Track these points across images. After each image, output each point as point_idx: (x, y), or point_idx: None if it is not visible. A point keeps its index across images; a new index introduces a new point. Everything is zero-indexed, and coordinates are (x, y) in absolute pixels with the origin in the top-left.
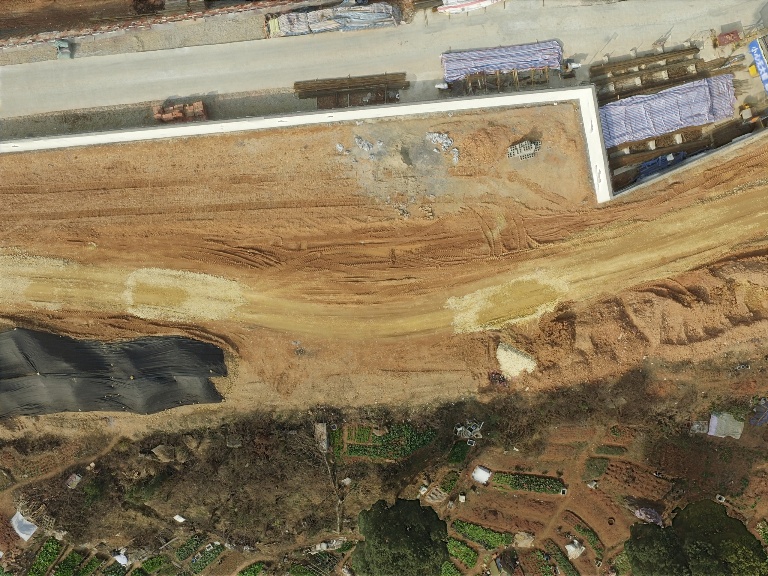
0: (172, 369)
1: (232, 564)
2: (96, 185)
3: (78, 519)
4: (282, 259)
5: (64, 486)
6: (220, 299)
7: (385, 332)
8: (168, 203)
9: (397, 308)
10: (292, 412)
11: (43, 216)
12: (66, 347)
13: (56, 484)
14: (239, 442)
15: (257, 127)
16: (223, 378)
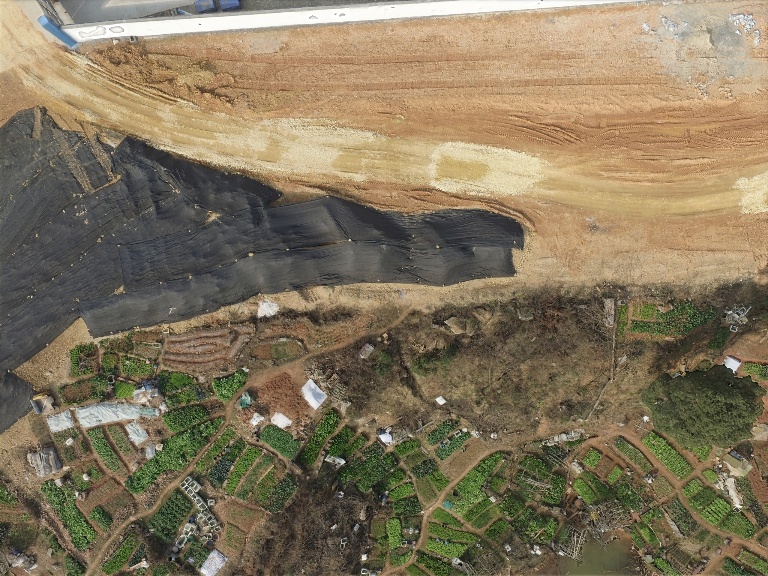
0: (475, 240)
1: (474, 453)
2: (410, 58)
3: (362, 391)
4: (582, 136)
5: (356, 356)
6: (520, 174)
7: (675, 211)
8: (479, 77)
9: (688, 188)
10: (580, 288)
11: (358, 87)
12: (372, 217)
13: (348, 354)
14: (531, 315)
15: (569, 4)
16: (520, 251)
